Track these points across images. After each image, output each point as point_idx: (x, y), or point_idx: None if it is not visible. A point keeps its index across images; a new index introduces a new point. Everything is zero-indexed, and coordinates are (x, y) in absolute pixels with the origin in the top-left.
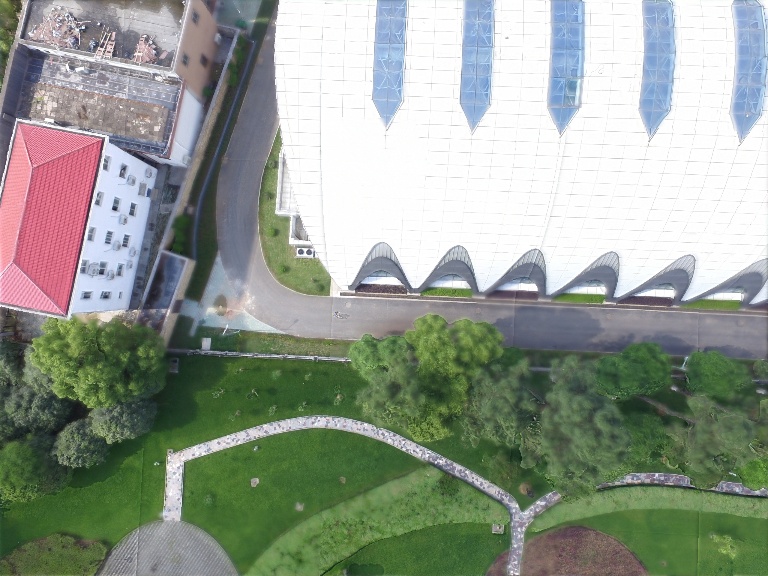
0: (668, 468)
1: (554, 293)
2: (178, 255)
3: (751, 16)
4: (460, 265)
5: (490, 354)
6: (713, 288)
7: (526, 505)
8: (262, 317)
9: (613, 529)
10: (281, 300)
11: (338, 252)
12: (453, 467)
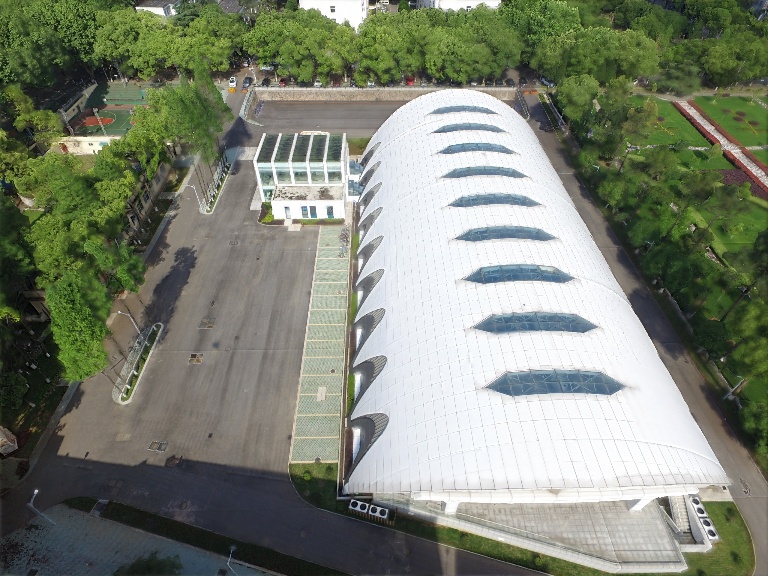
0: None
1: None
2: None
3: None
4: None
5: None
6: None
7: None
8: None
9: None
10: None
11: None
12: None
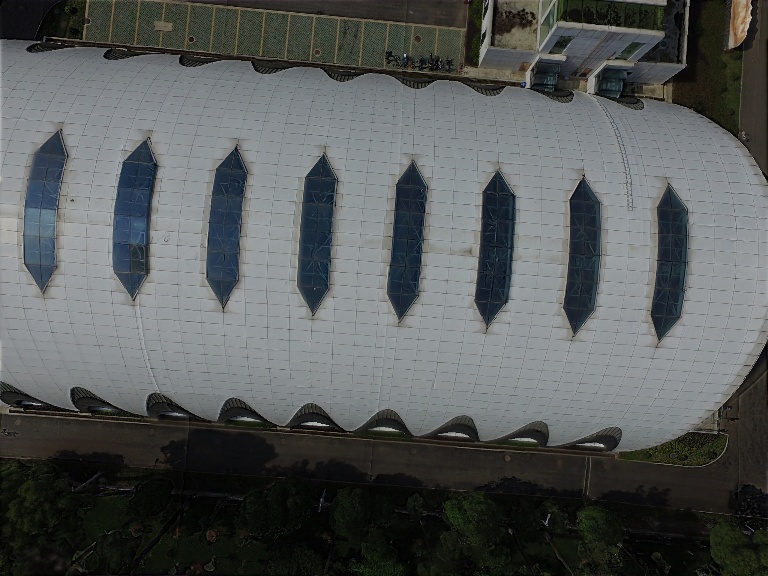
0: None
1: (218, 420)
2: None
3: (331, 186)
4: (94, 401)
5: (34, 526)
6: (362, 426)
7: None
8: None
9: None
10: None
11: None
12: None
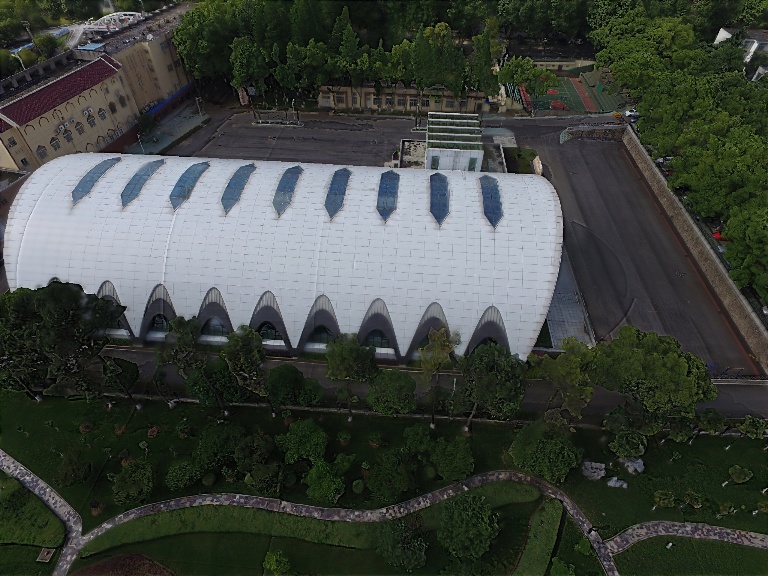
0: (251, 490)
1: None
2: None
3: None
4: None
5: None
6: (304, 328)
7: (90, 528)
8: None
9: (173, 559)
10: None
11: None
12: (36, 484)
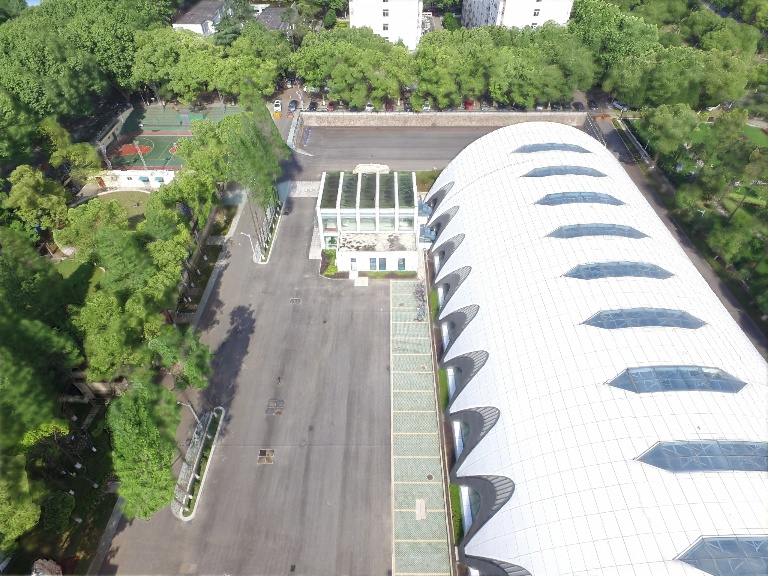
0: None
1: None
2: None
3: None
4: None
5: None
6: None
7: None
8: None
9: None
10: None
11: None
12: None
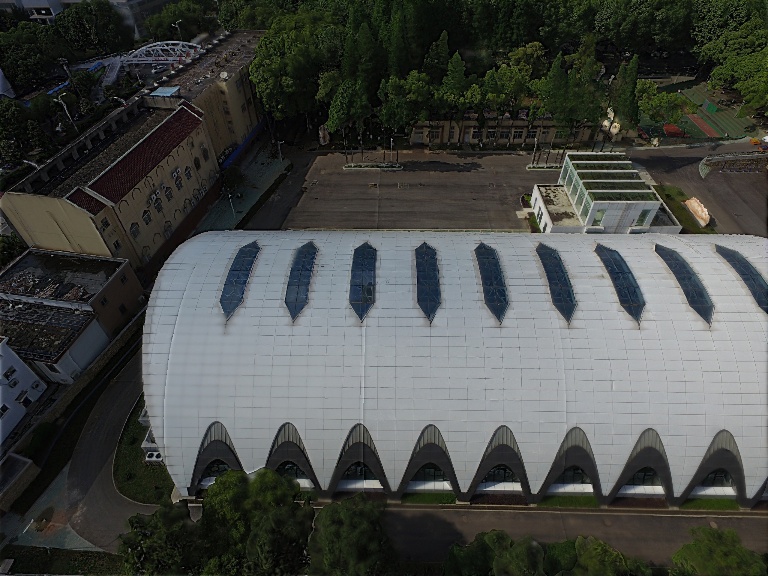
0: None
1: (399, 488)
2: (24, 457)
3: None
4: (293, 447)
5: (277, 493)
6: (550, 470)
7: None
8: (85, 532)
9: None
10: (113, 511)
11: (175, 436)
12: None
